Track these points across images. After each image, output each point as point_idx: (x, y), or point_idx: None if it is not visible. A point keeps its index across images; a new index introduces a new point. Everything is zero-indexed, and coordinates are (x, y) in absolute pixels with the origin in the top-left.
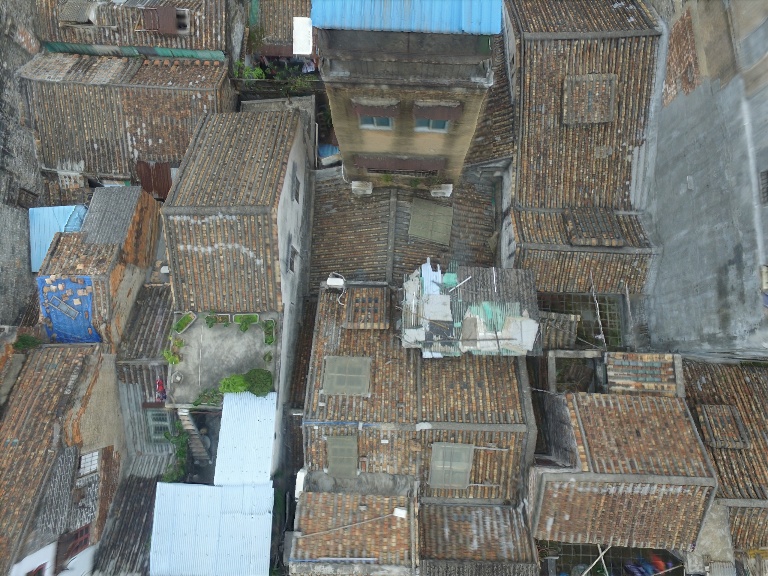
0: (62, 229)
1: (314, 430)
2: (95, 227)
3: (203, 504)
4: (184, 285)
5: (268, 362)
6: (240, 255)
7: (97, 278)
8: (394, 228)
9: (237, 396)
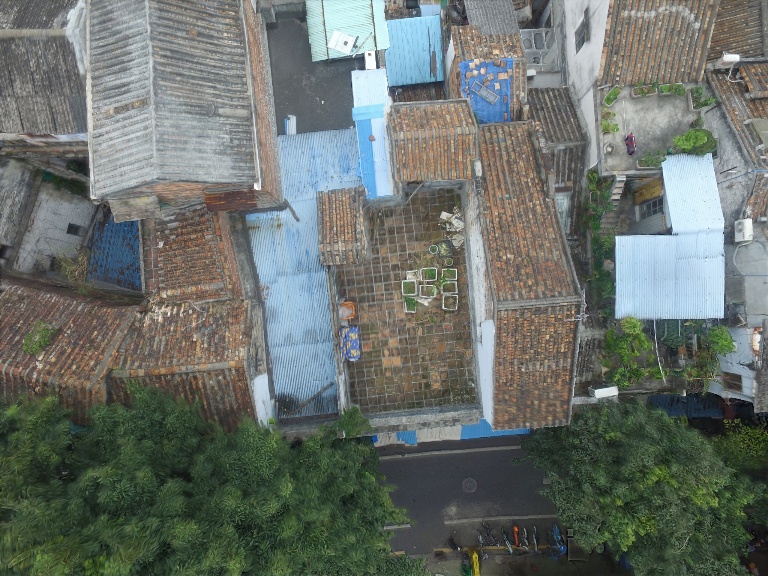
0: (410, 42)
1: (761, 179)
2: (484, 21)
3: (659, 252)
4: (615, 57)
5: (693, 129)
6: (679, 20)
7: (520, 60)
8: (767, 10)
9: (674, 159)
